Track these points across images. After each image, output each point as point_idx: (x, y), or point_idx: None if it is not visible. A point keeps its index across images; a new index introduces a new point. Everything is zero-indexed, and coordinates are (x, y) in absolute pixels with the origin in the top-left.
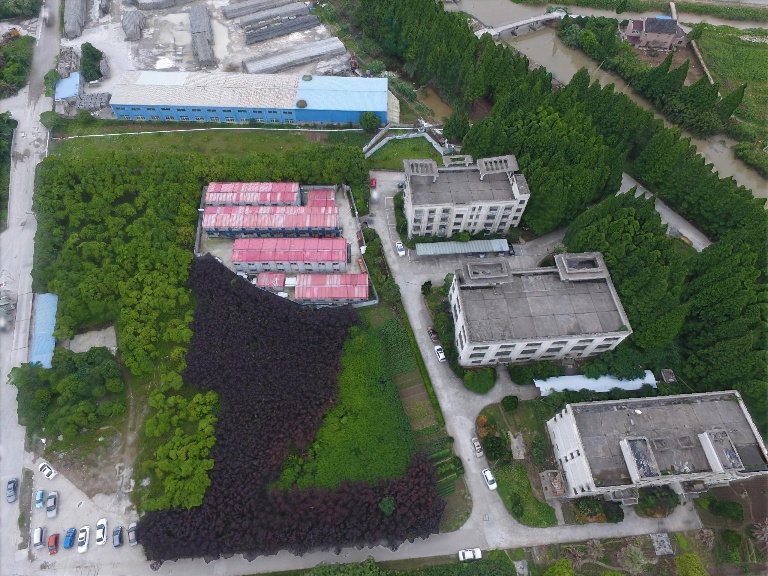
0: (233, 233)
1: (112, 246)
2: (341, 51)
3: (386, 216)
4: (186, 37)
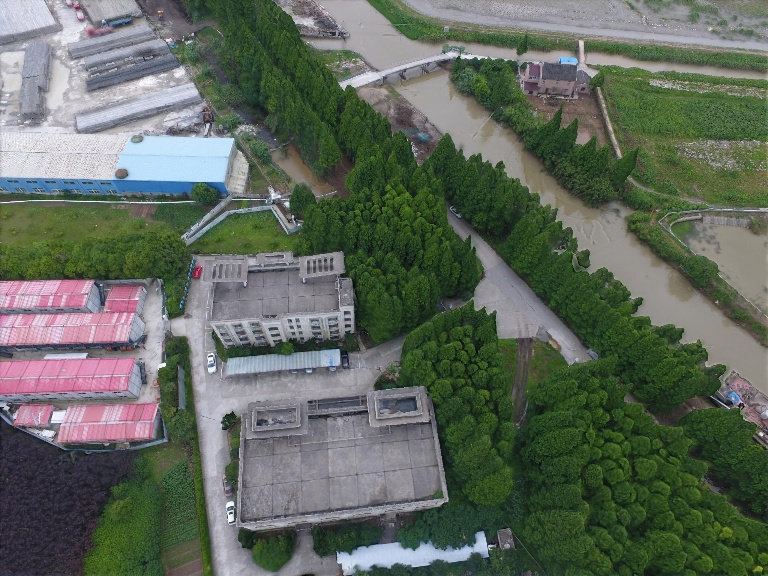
0: (2, 348)
1: None
2: (195, 100)
3: (205, 317)
4: (17, 81)
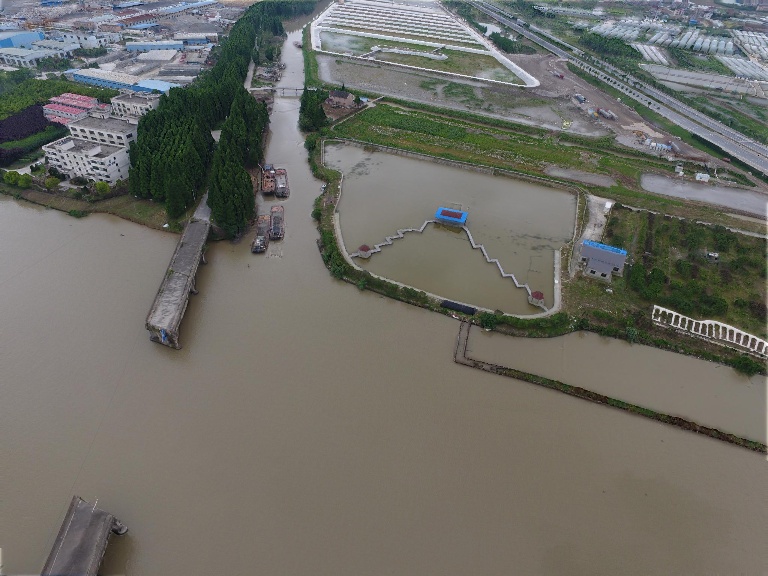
0: None
1: None
2: (189, 82)
3: None
4: None
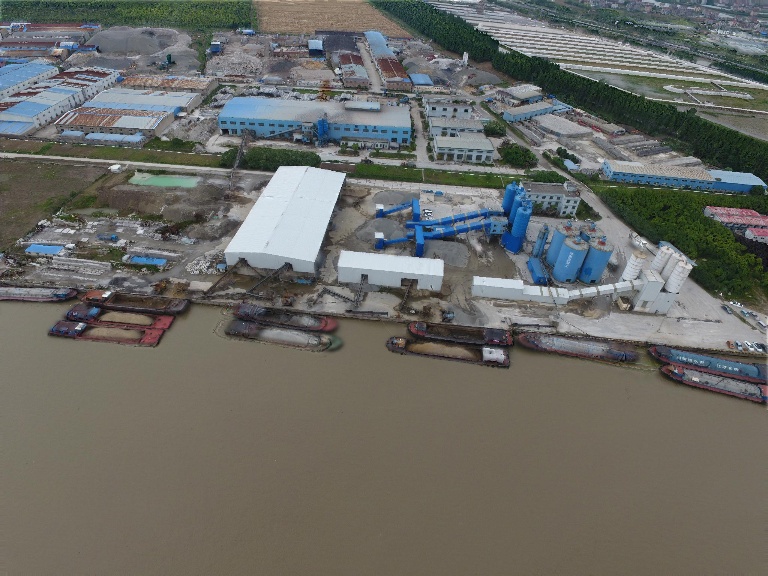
0: (733, 228)
1: (680, 226)
2: (699, 163)
3: None
4: (600, 151)
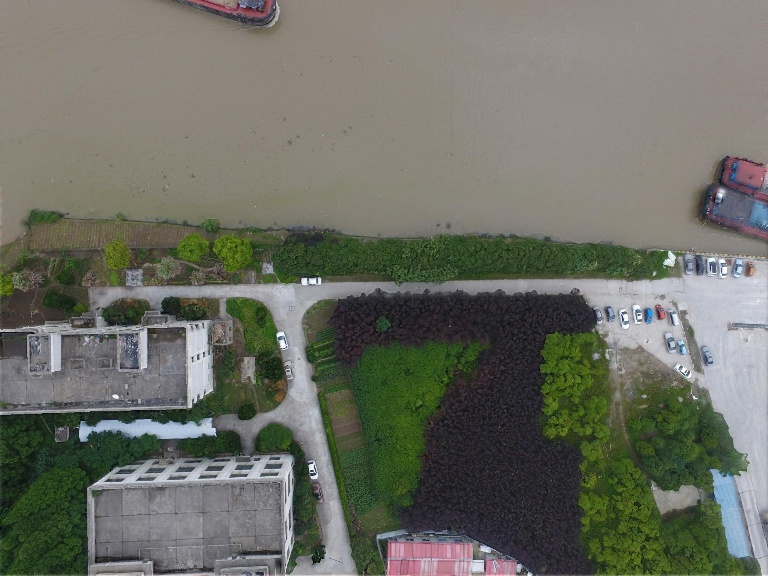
0: None
1: None
2: None
3: None
4: None
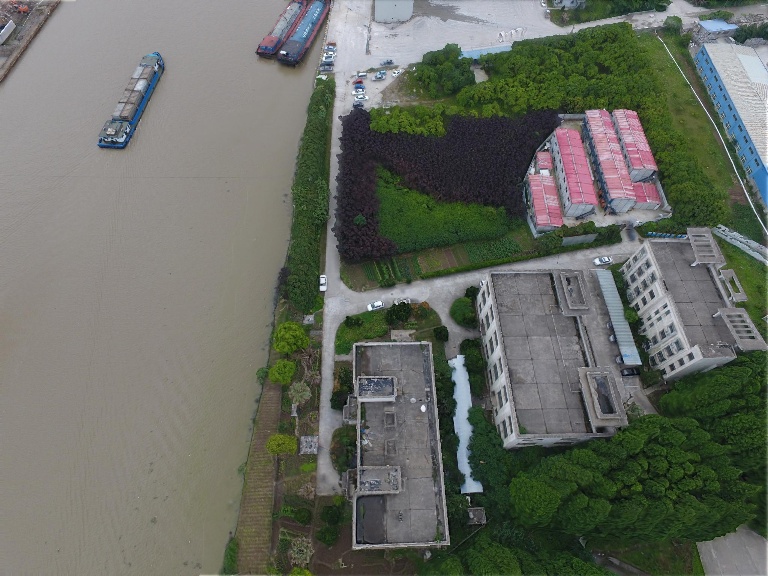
0: (587, 135)
1: None
2: None
3: None
4: None
